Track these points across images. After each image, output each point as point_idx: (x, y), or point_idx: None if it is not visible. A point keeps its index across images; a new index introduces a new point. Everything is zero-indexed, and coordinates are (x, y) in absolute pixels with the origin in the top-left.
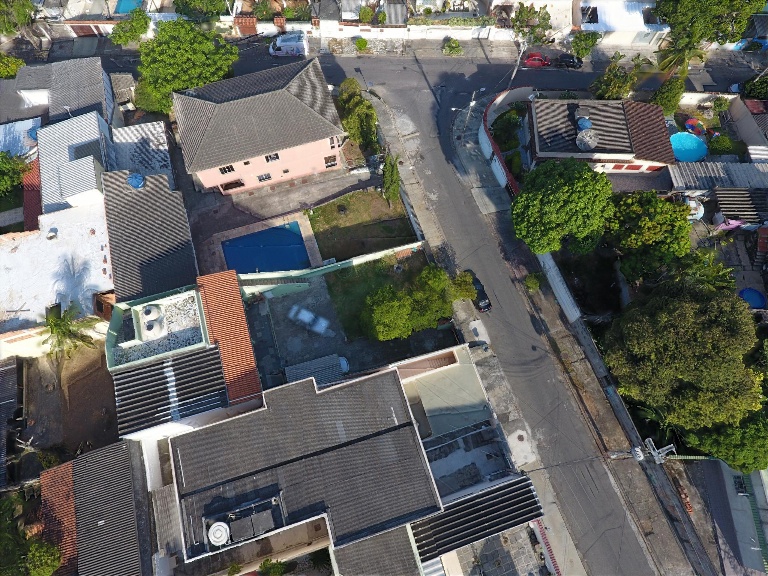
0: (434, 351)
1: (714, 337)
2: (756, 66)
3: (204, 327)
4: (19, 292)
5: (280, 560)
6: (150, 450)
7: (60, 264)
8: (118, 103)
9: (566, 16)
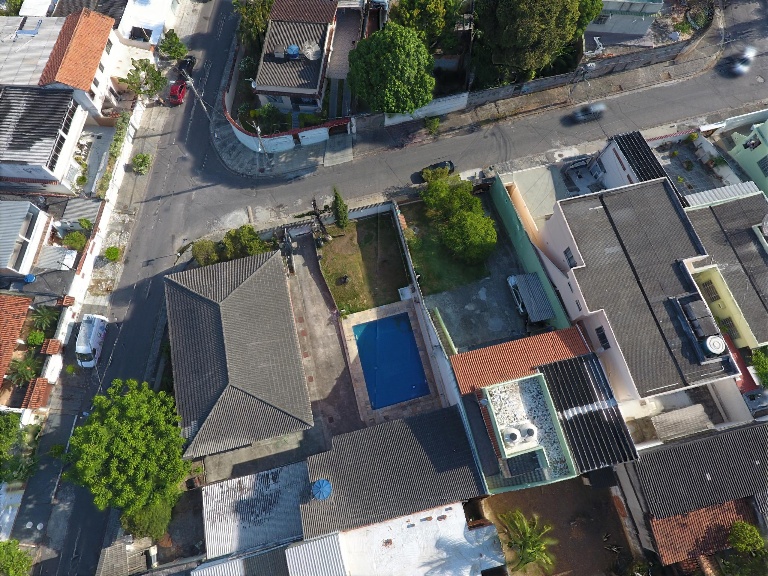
0: None
1: None
2: None
3: None
4: None
5: None
6: None
7: None
8: (147, 569)
9: (136, 53)
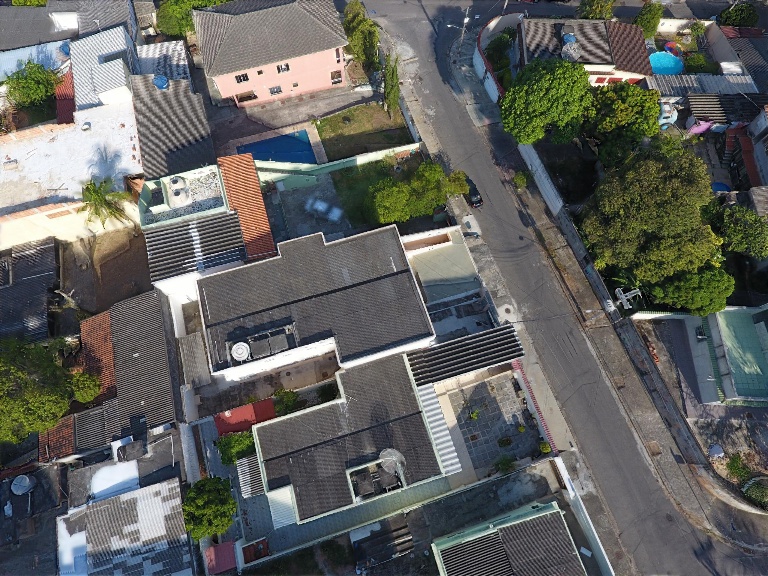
0: (430, 232)
1: (673, 186)
2: None
3: (225, 196)
4: (58, 174)
5: (292, 390)
6: (176, 308)
7: (94, 152)
8: (140, 28)
9: None
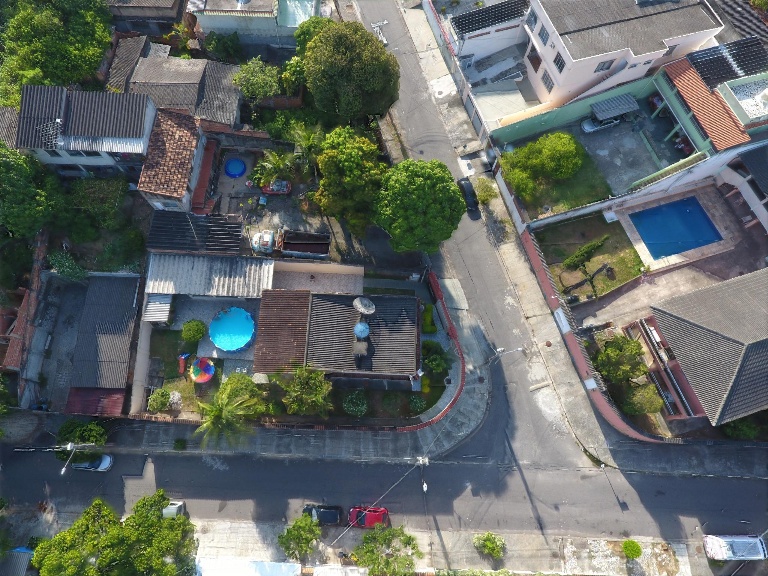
0: None
1: None
2: (49, 515)
3: (728, 98)
4: None
5: None
6: None
7: None
8: None
9: None
